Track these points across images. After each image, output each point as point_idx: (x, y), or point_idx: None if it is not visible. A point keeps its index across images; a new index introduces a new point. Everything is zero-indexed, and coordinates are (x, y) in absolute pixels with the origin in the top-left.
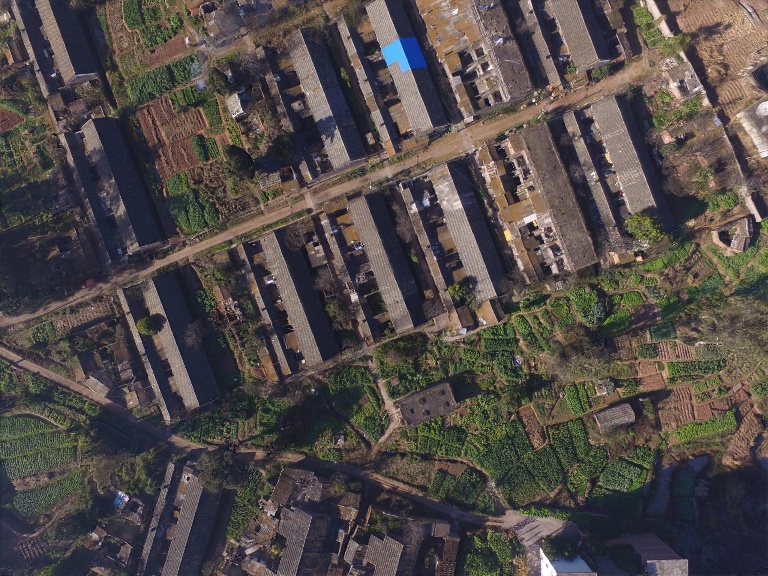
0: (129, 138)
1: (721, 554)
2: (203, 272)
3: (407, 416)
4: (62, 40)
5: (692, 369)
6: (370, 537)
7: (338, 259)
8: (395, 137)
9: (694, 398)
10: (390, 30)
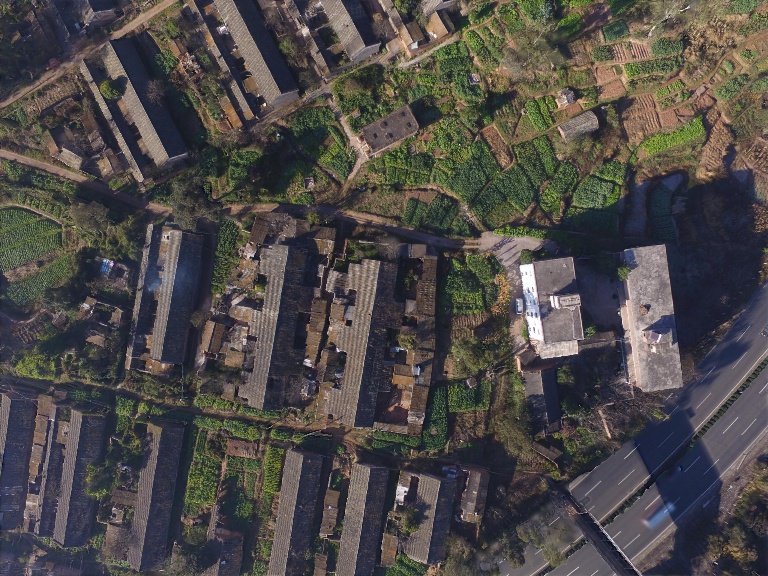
0: None
1: (706, 270)
2: (159, 36)
3: (371, 141)
4: None
5: (650, 67)
6: (349, 266)
7: None
8: None
9: (658, 105)
10: None
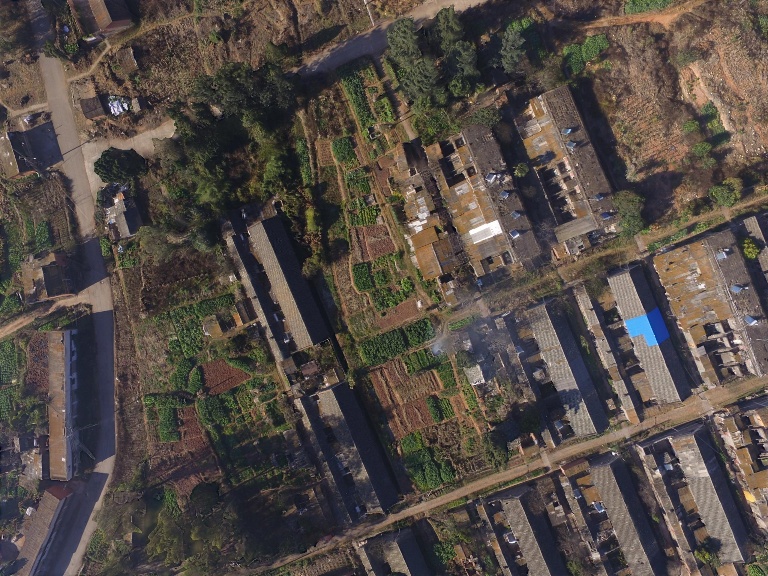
0: (362, 398)
1: None
2: (439, 526)
3: None
4: (298, 311)
5: None
6: None
7: (579, 520)
8: (638, 405)
9: None
10: (636, 305)
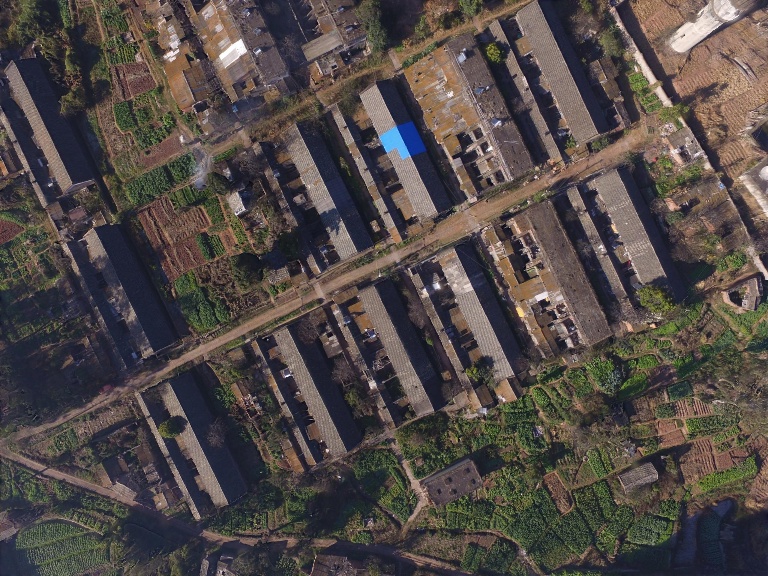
0: (132, 241)
1: None
2: (219, 369)
3: (434, 497)
4: (56, 150)
5: (711, 424)
6: None
7: (353, 348)
8: (400, 224)
9: (714, 449)
10: (386, 118)
